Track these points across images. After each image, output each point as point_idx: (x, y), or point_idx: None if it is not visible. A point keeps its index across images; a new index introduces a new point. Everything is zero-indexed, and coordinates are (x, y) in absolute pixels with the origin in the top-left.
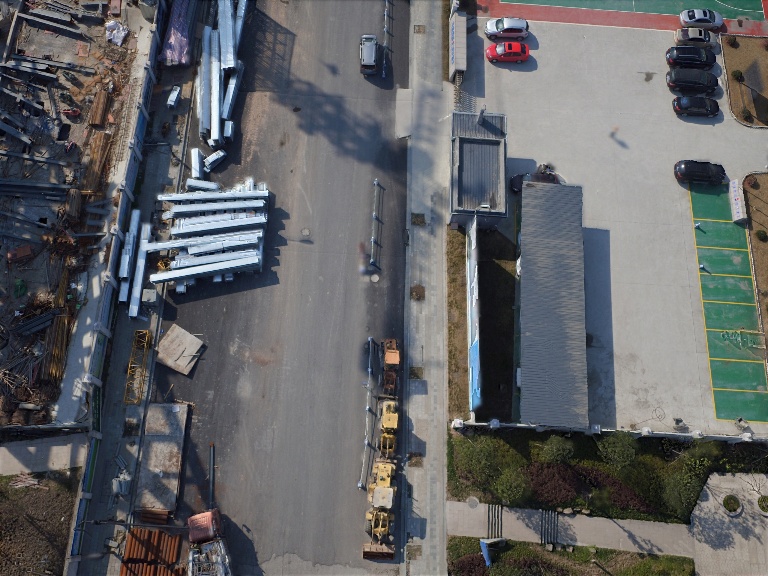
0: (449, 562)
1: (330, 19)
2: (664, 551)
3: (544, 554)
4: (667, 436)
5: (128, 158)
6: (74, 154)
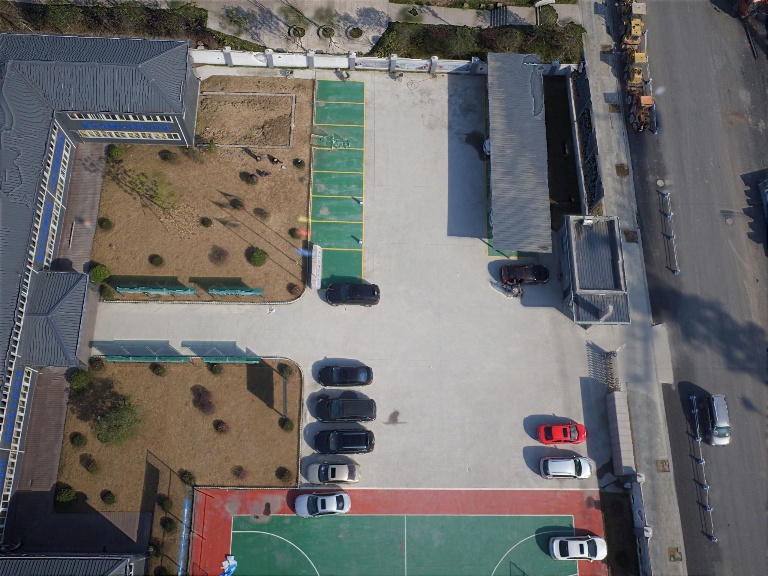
0: None
1: (765, 473)
2: (411, 6)
3: (504, 1)
4: (407, 71)
5: None
6: None
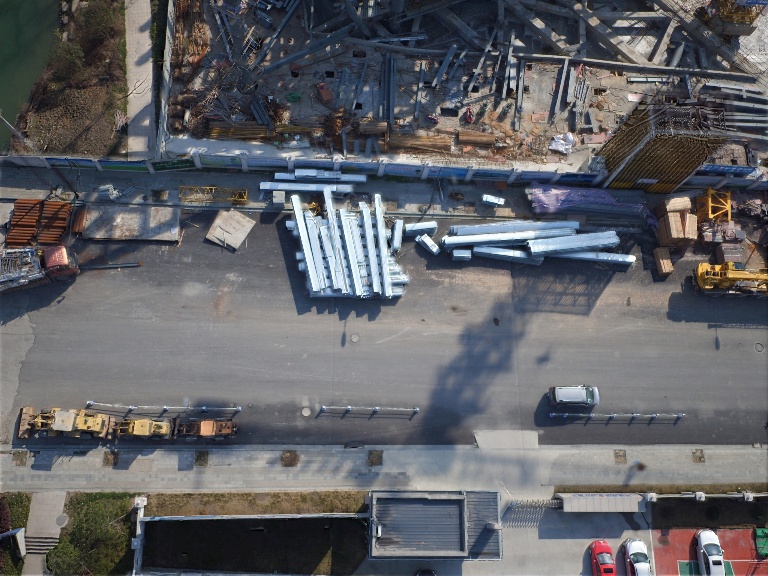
0: (5, 494)
1: (616, 352)
2: None
3: None
4: None
5: None
6: (427, 123)
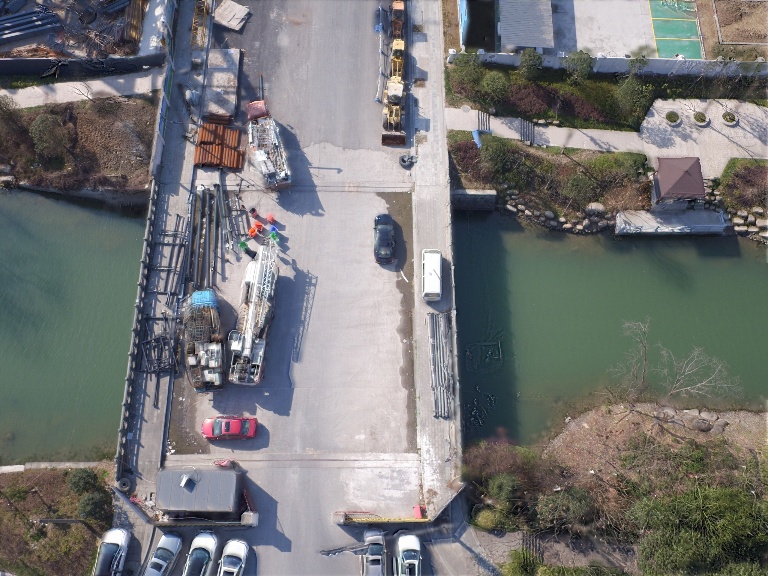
0: (449, 145)
1: None
2: (619, 149)
3: (524, 147)
4: (619, 70)
5: None
6: None
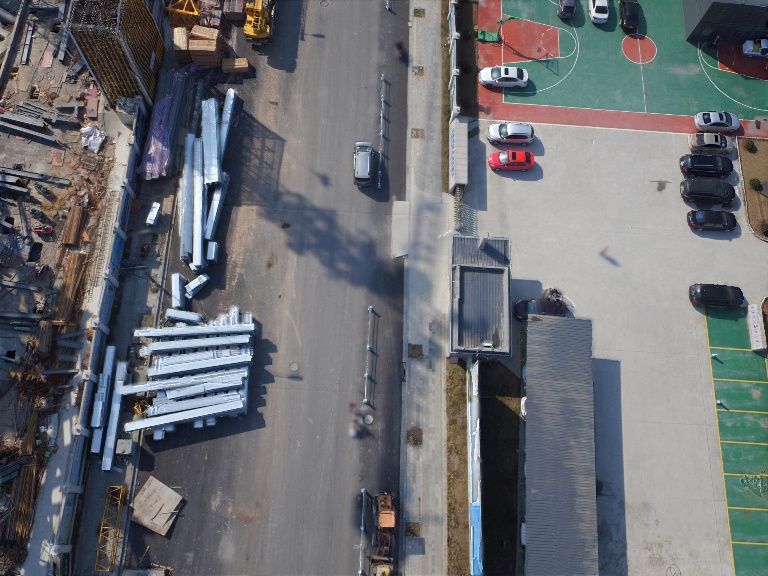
0: None
1: (322, 122)
2: None
3: None
4: None
5: (103, 289)
6: (46, 277)
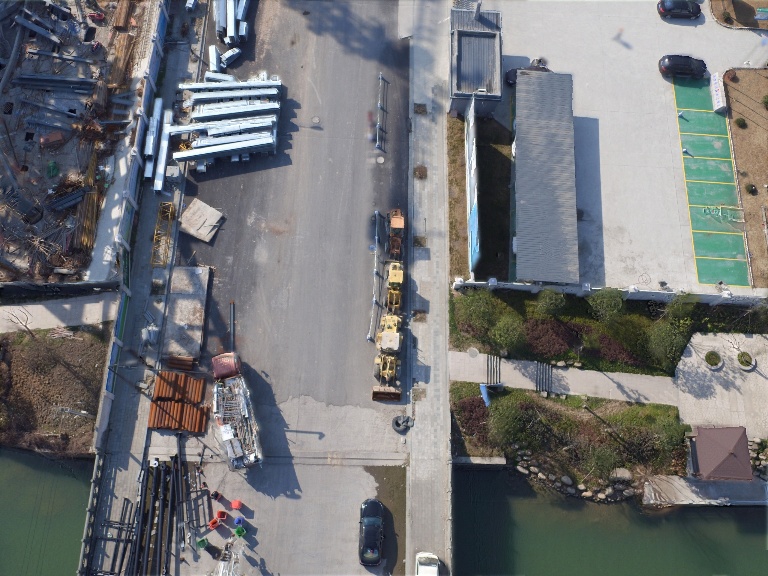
0: (452, 403)
1: None
2: (650, 400)
3: (539, 400)
4: (653, 298)
5: (151, 51)
6: (100, 53)
